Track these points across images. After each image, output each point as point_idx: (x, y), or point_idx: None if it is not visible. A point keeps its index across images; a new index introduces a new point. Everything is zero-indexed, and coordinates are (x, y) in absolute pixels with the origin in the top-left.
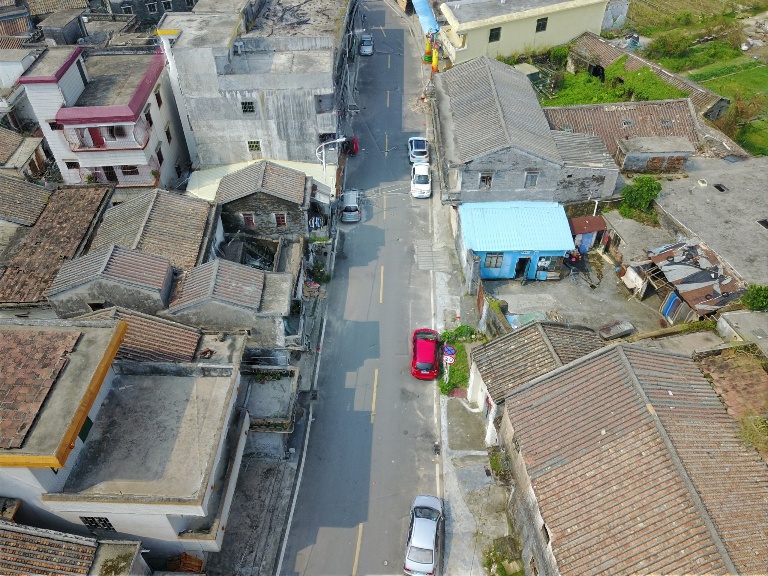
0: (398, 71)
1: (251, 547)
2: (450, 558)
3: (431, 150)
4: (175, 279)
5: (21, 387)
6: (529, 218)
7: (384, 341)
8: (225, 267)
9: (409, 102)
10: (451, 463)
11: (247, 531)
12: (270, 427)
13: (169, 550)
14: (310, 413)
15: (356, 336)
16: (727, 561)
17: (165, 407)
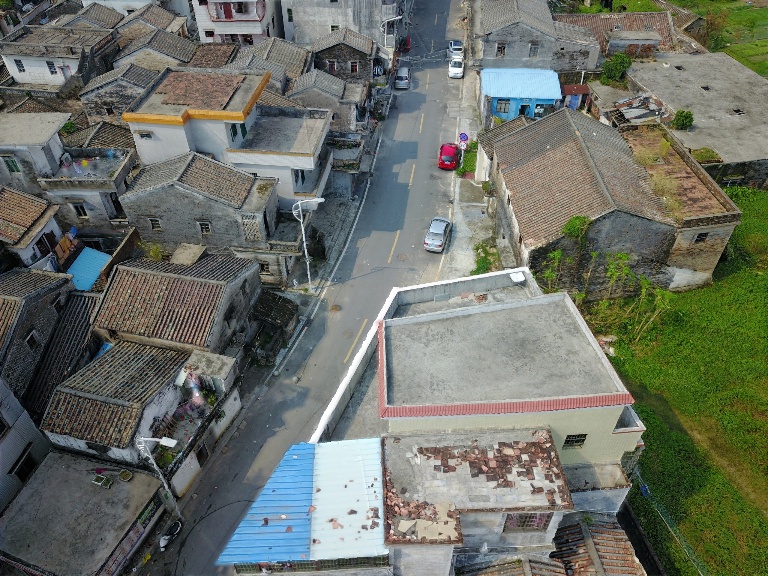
0: (446, 2)
1: (330, 233)
2: (453, 246)
3: (466, 51)
4: (287, 83)
5: (217, 92)
6: (531, 79)
7: (421, 151)
8: (321, 74)
9: (453, 22)
10: (460, 208)
11: (328, 227)
12: (345, 168)
13: (287, 209)
14: (368, 182)
15: (401, 148)
16: (601, 183)
17: (288, 129)
